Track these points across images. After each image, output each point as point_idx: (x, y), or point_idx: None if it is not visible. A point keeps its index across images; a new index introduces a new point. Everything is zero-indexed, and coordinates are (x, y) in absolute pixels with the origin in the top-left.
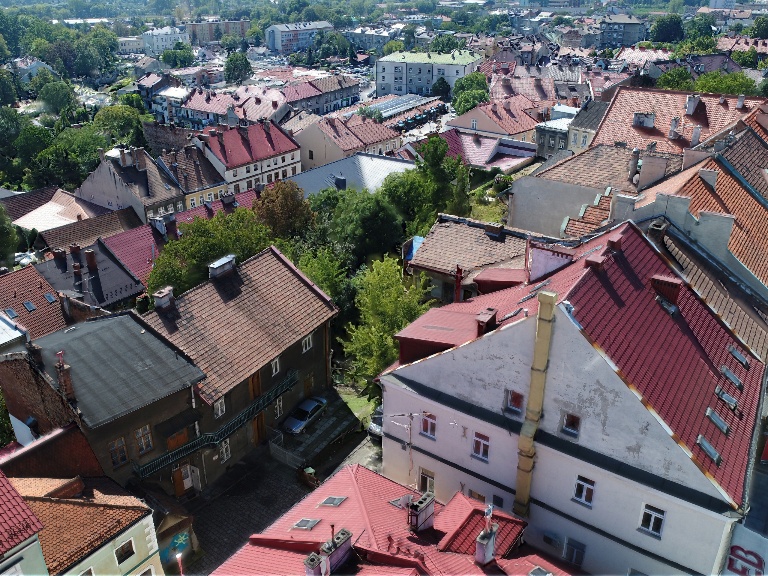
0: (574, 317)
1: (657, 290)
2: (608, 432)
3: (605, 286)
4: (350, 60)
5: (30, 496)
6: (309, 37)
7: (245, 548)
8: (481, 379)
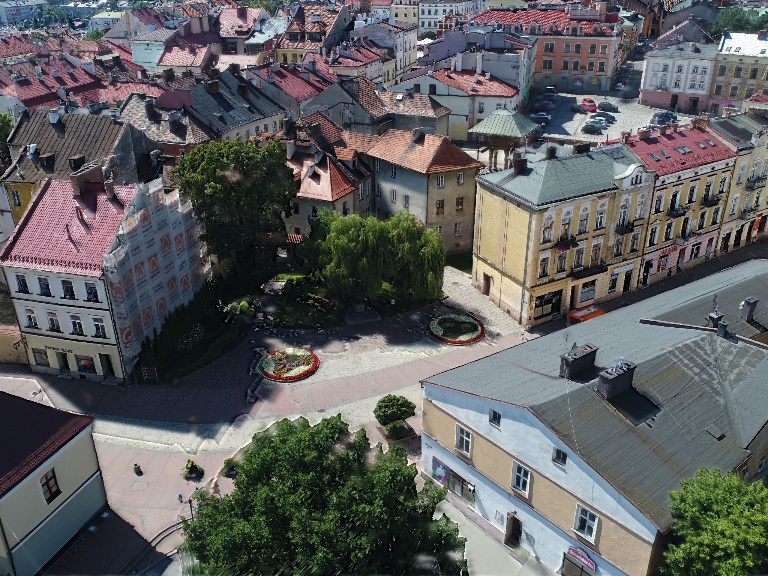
0: (132, 13)
1: (156, 17)
2: (142, 33)
3: (141, 13)
4: (69, 25)
5: None
6: (30, 11)
7: None
8: (120, 31)
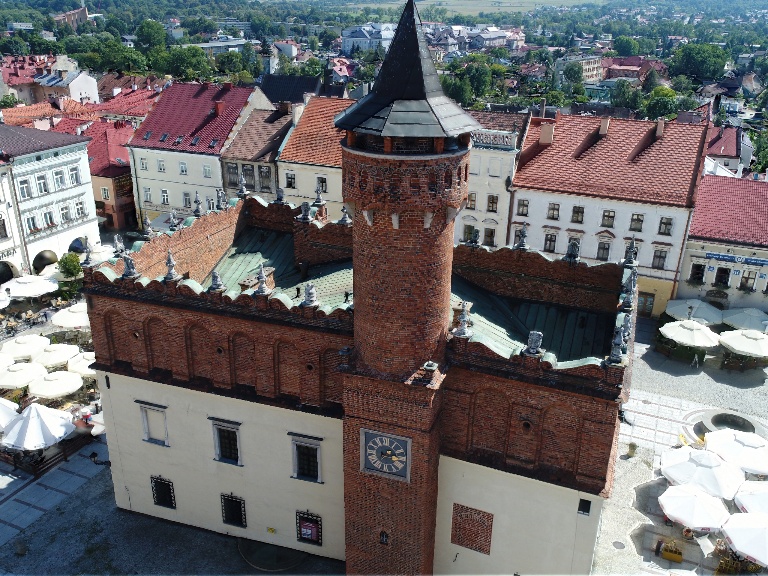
0: None
1: None
2: None
3: None
4: None
5: None
6: None
7: None
8: None
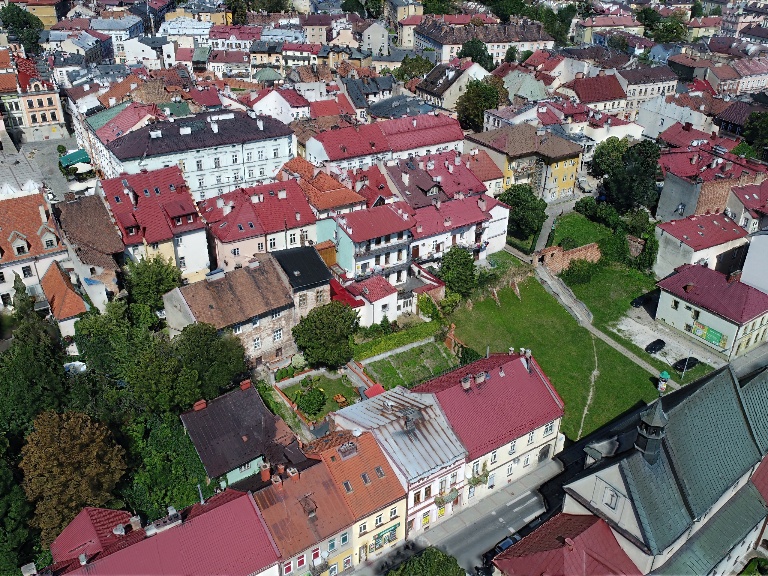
0: None
1: None
2: None
3: None
4: None
5: (320, 243)
6: None
7: (268, 231)
8: None
